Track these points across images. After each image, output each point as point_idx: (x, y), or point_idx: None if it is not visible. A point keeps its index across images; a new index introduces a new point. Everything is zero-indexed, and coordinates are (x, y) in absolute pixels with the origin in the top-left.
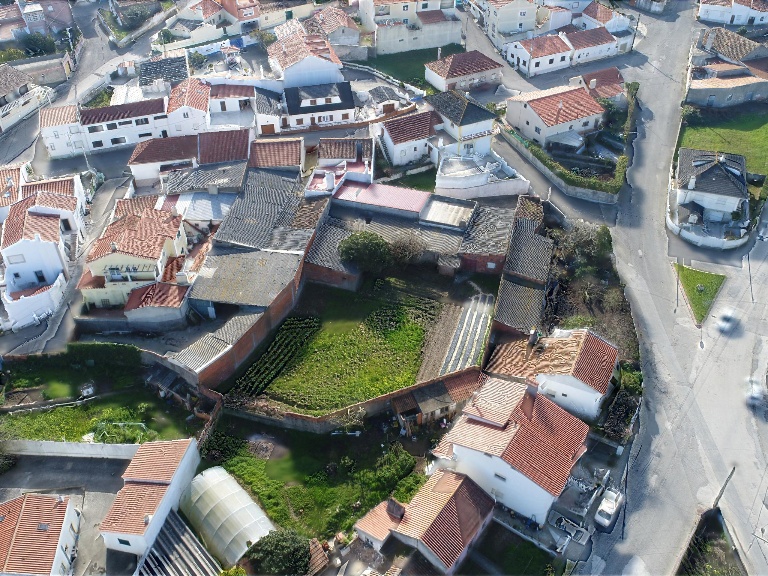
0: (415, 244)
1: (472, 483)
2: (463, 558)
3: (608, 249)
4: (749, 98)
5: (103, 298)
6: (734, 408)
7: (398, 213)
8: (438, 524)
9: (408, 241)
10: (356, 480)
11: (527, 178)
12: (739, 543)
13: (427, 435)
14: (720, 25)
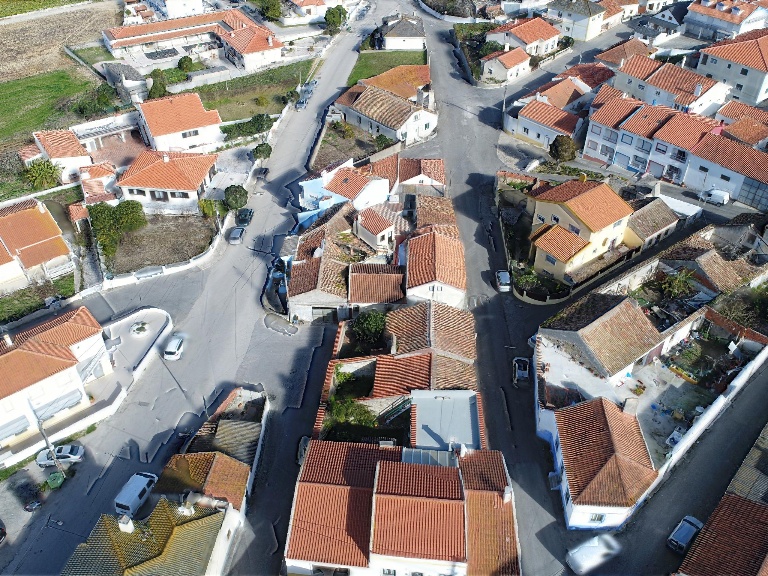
0: None
1: None
2: None
3: None
4: None
5: None
6: (383, 2)
7: None
8: None
9: None
10: None
11: None
12: None
13: None
14: None
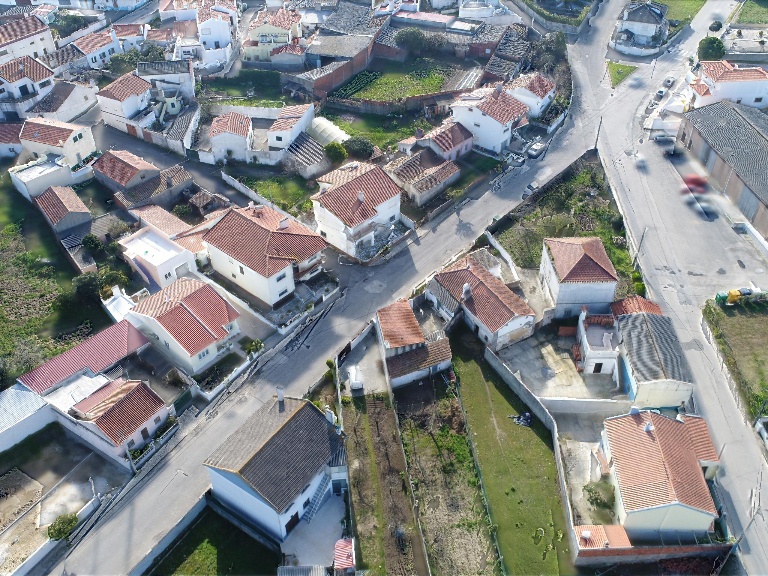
0: (442, 37)
1: (461, 126)
2: (454, 160)
3: (563, 46)
4: None
5: (256, 55)
6: (622, 119)
7: (433, 25)
8: (441, 136)
9: (438, 35)
10: (399, 131)
11: (521, 19)
12: (605, 163)
13: (440, 119)
14: None
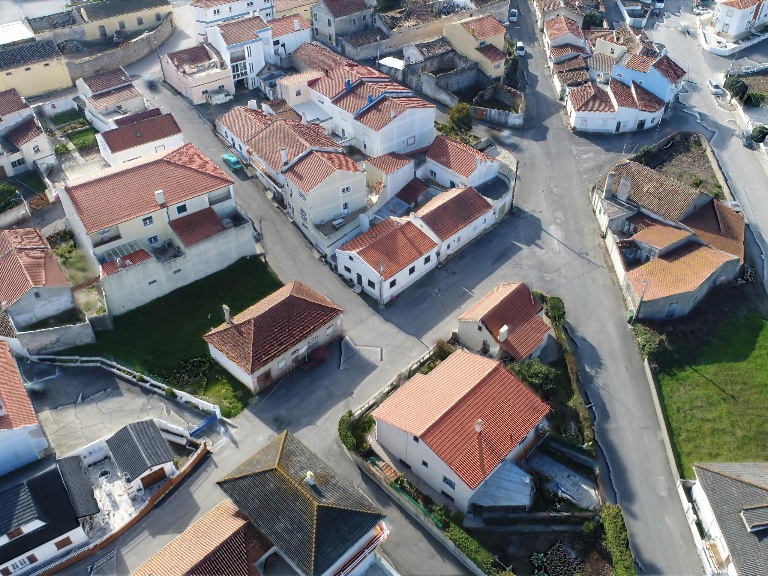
0: None
1: None
2: None
3: None
4: (711, 283)
5: None
6: None
7: None
8: None
9: None
10: None
11: None
12: None
13: None
14: (605, 137)
